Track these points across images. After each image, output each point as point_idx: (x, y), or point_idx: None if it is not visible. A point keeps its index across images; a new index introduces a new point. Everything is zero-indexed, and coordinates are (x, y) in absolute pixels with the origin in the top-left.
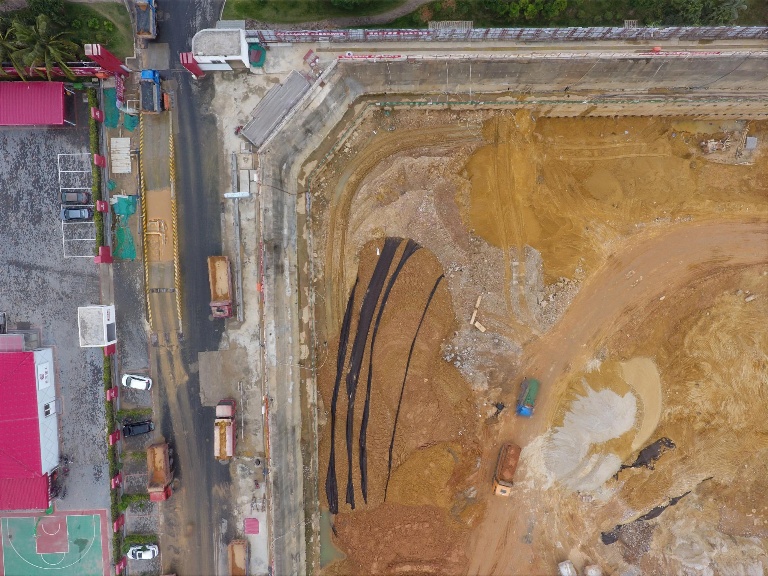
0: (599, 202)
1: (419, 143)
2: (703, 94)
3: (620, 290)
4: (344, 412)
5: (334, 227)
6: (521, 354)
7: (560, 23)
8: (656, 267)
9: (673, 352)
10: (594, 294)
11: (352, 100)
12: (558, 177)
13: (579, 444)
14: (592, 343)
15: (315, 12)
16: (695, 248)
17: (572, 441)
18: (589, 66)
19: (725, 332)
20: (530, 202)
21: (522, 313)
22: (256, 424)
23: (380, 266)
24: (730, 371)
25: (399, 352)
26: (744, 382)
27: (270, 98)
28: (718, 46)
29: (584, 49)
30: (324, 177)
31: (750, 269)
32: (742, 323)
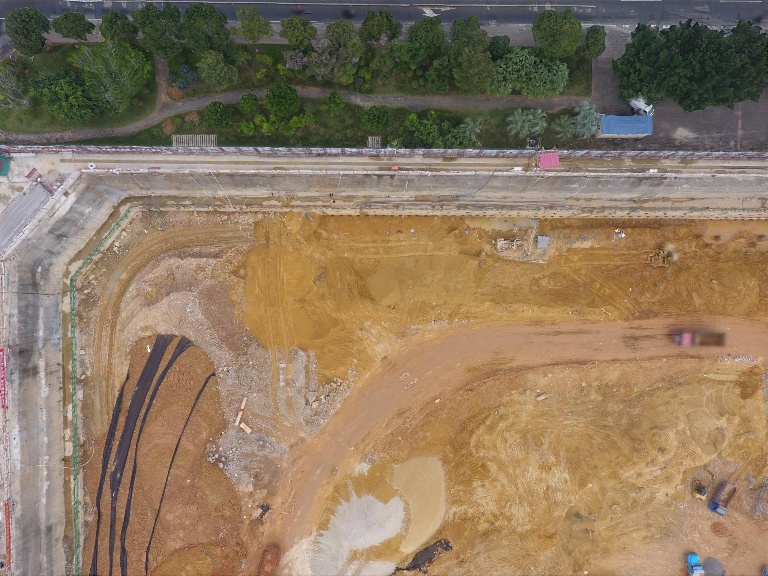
0: (375, 303)
1: (190, 243)
2: (470, 202)
3: (393, 392)
4: (108, 510)
5: (103, 324)
6: (287, 456)
7: (304, 138)
8: (432, 369)
9: (459, 451)
10: (366, 396)
11: (117, 202)
12: (339, 275)
13: (338, 551)
14: (361, 446)
15: (59, 123)
16: (474, 350)
17: (333, 547)
18: (335, 180)
19: (514, 431)
20: (302, 303)
21: (289, 415)
22: (0, 527)
23: (150, 364)
24: (516, 472)
25: (163, 451)
26: (529, 483)
27: (13, 207)
28: (462, 164)
29: (327, 164)
30: (93, 275)
31: (534, 371)
32: (534, 421)
